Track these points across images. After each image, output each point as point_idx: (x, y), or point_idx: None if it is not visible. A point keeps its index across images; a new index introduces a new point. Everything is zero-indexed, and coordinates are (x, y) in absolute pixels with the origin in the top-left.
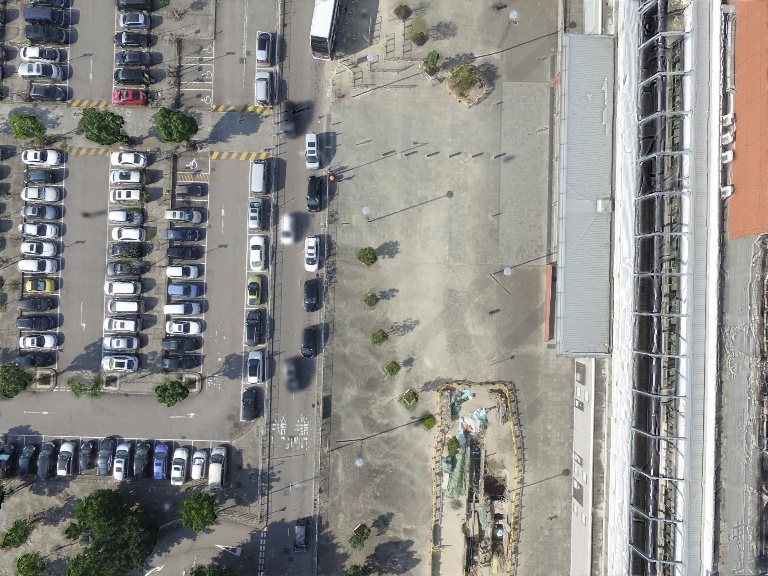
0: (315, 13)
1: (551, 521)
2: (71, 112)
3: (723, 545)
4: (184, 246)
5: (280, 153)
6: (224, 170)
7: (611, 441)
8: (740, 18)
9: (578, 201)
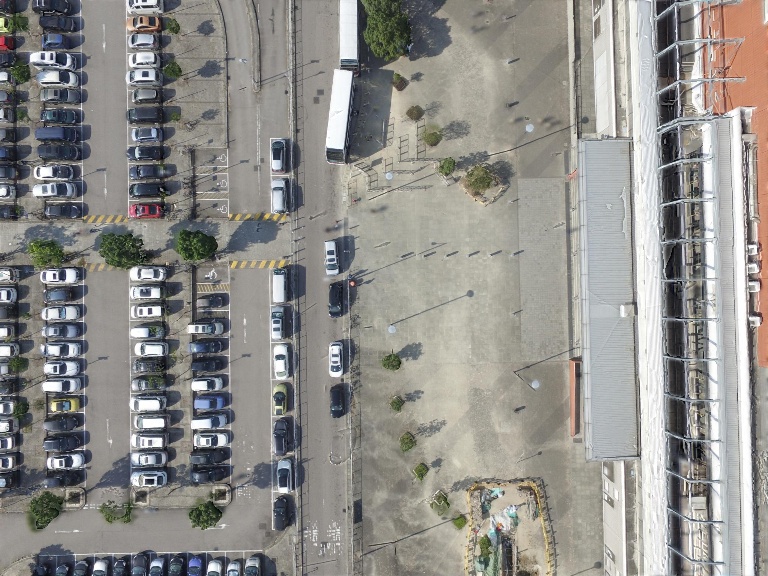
0: (329, 125)
1: None
2: (87, 229)
3: None
4: (207, 358)
5: (299, 259)
6: (244, 279)
7: (644, 544)
8: (761, 149)
9: (601, 307)
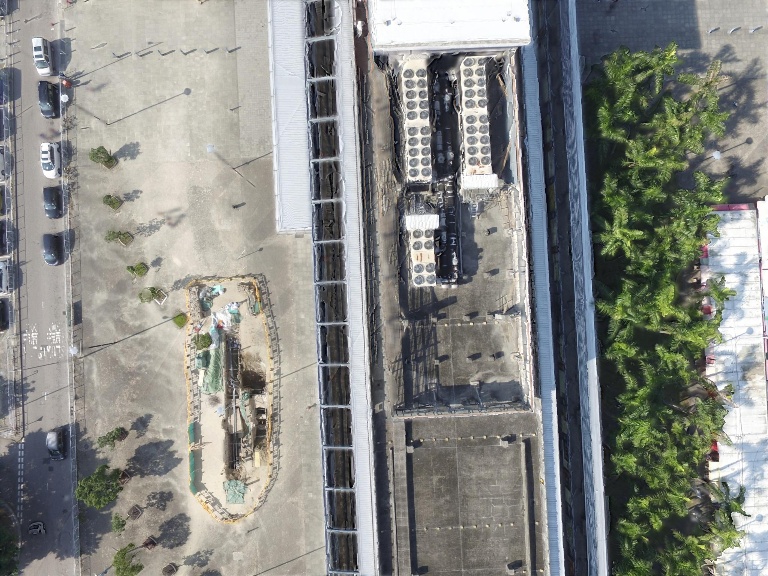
0: None
1: (310, 410)
2: None
3: (388, 383)
4: None
5: (14, 63)
6: None
7: None
8: None
9: (287, 77)
